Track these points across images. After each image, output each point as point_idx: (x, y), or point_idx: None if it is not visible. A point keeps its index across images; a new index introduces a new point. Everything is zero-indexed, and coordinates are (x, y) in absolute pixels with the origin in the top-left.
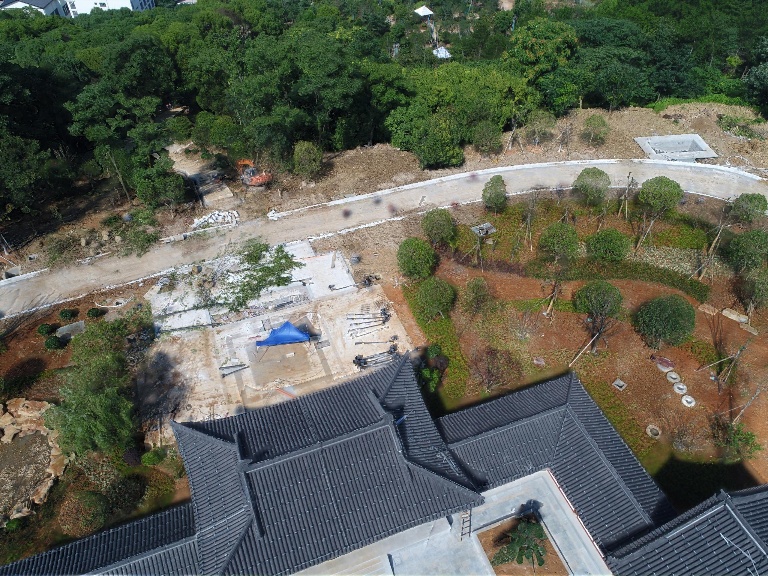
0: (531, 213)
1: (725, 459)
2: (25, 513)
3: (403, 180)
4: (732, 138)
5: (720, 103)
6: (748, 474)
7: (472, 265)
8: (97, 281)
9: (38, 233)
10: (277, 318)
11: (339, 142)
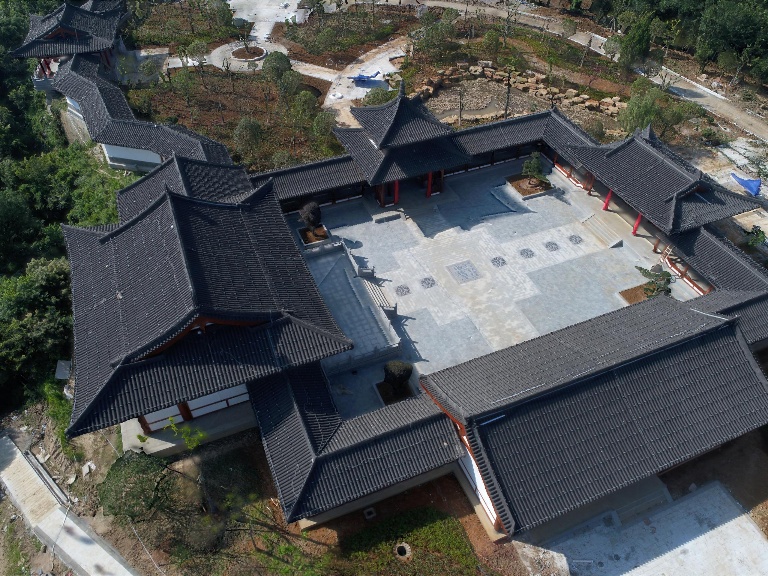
0: None
1: None
2: None
3: None
4: None
5: None
6: None
7: None
8: (737, 119)
9: (757, 92)
10: (767, 192)
11: None
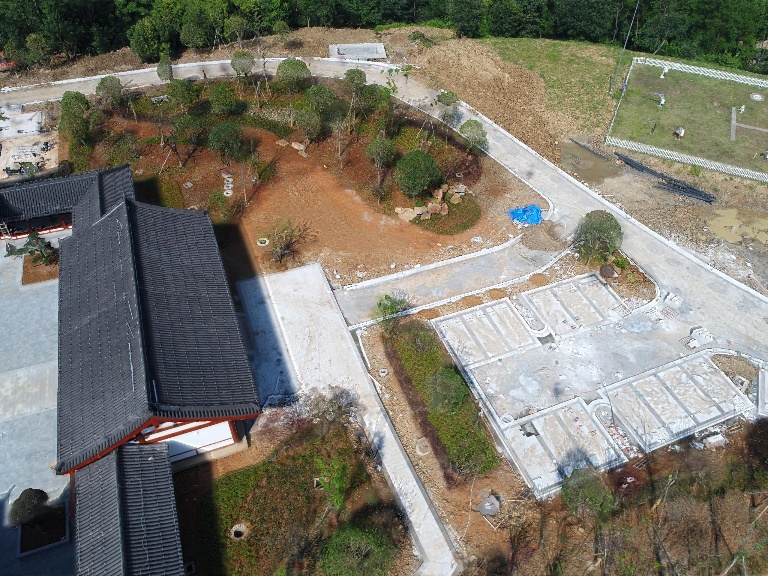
0: (202, 89)
1: None
2: None
3: (121, 69)
4: (413, 47)
5: (434, 27)
6: (238, 230)
7: (131, 118)
8: None
9: None
10: None
11: (97, 48)
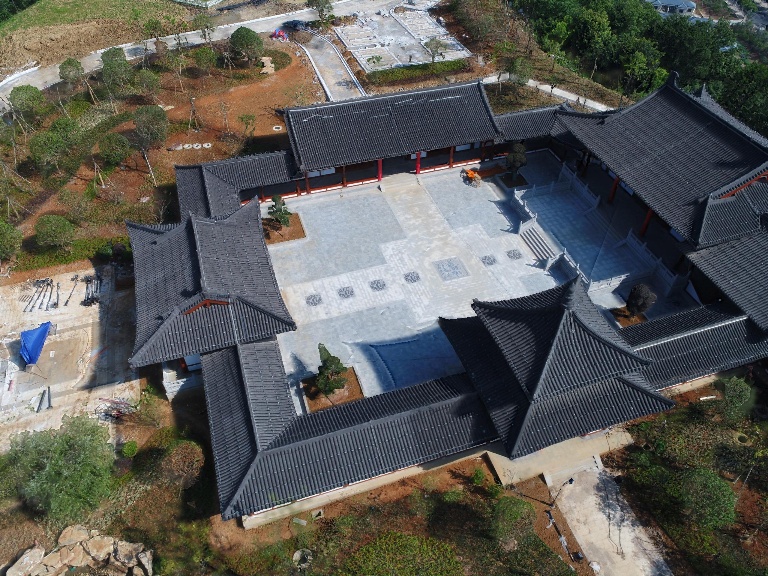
0: None
1: (250, 140)
2: (150, 558)
3: None
4: None
5: None
6: (260, 139)
7: (21, 220)
8: None
9: None
10: None
11: None
